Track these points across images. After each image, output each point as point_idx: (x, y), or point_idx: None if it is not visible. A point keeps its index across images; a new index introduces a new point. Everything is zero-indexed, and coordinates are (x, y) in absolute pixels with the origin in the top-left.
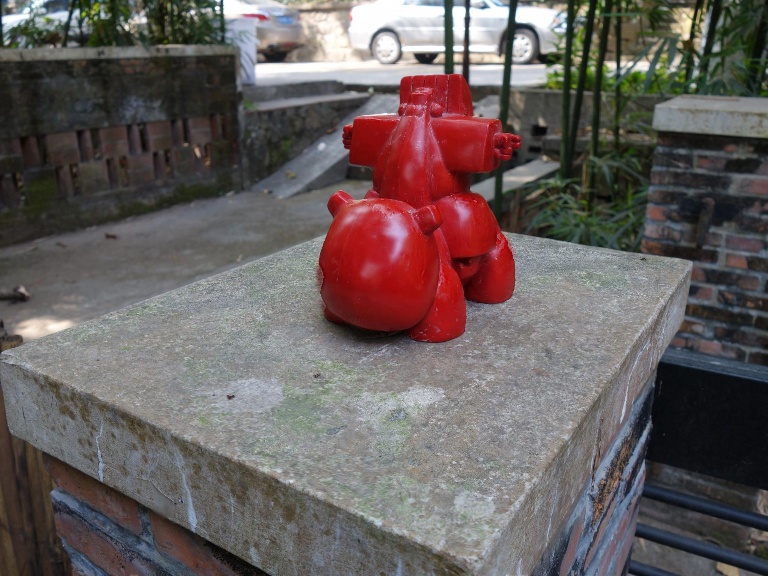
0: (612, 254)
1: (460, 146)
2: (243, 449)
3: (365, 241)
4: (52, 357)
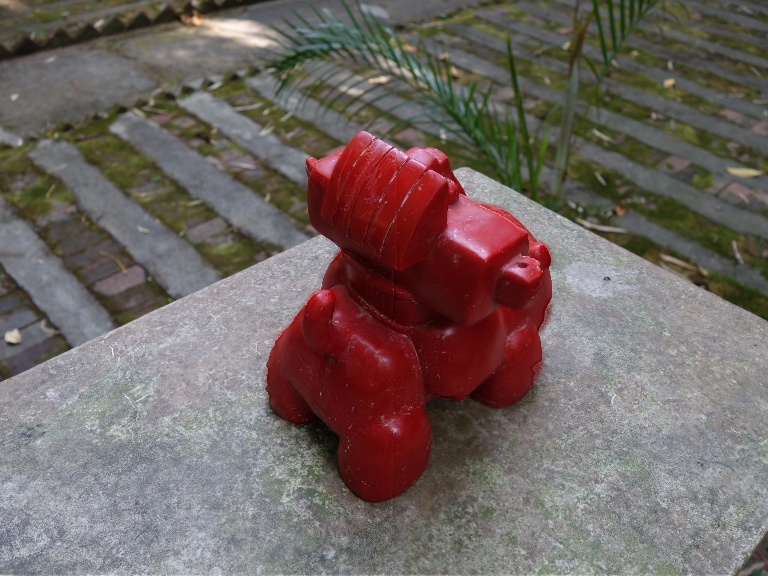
0: None
1: None
2: (584, 234)
3: None
4: None
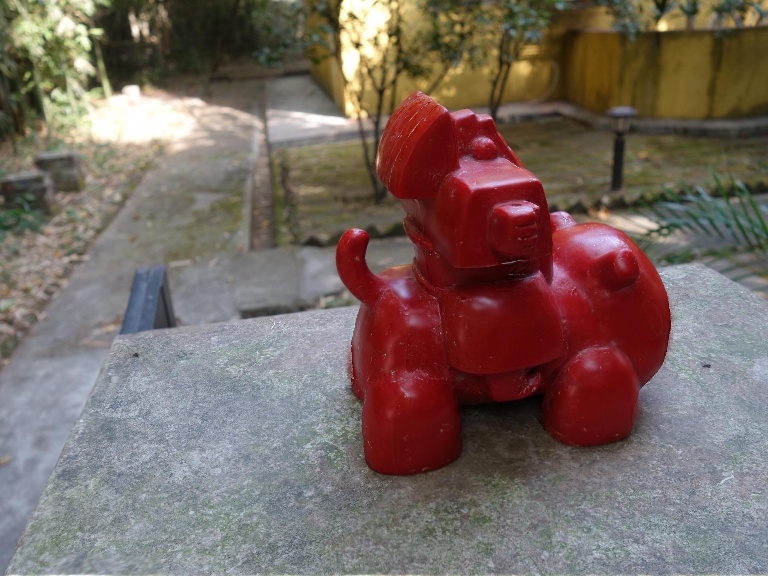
0: (123, 378)
1: None
2: None
3: None
4: None
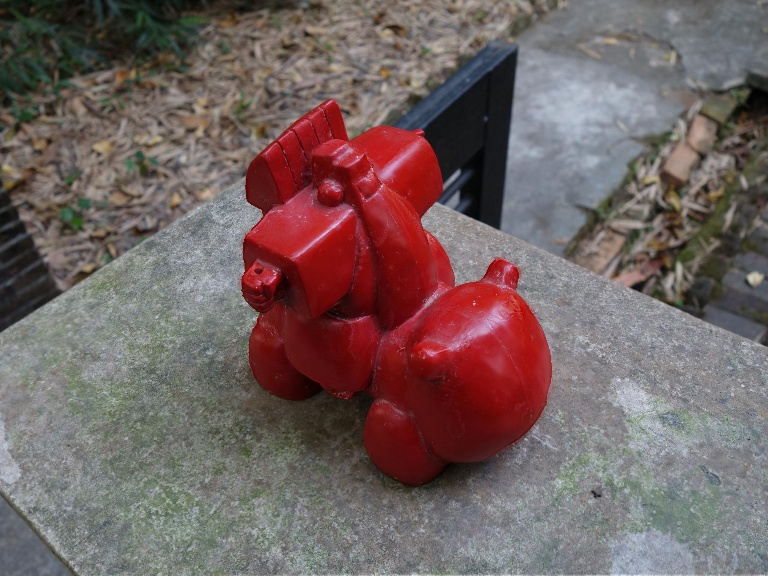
0: None
1: (424, 183)
2: None
3: (534, 353)
4: None
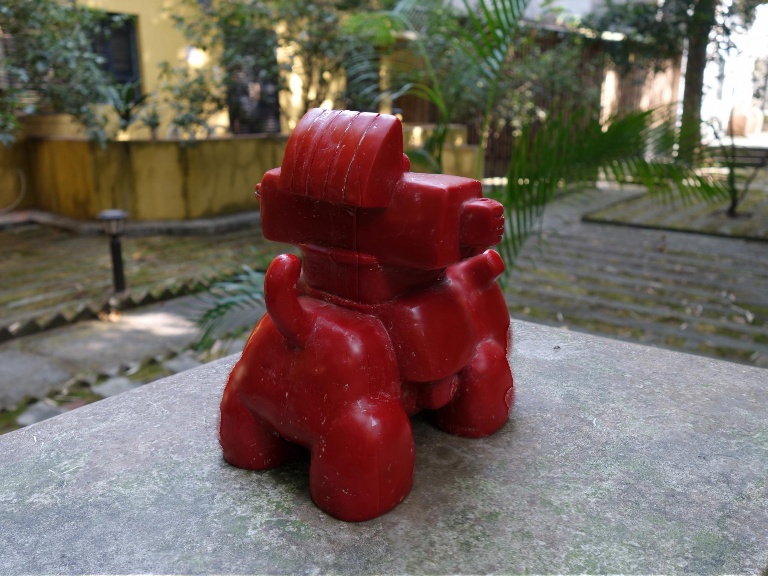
0: None
1: None
2: (525, 324)
3: None
4: (767, 378)
